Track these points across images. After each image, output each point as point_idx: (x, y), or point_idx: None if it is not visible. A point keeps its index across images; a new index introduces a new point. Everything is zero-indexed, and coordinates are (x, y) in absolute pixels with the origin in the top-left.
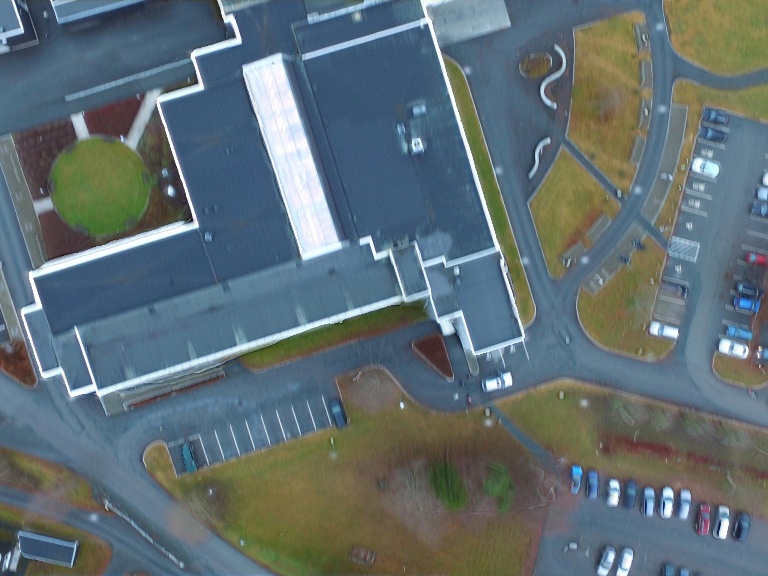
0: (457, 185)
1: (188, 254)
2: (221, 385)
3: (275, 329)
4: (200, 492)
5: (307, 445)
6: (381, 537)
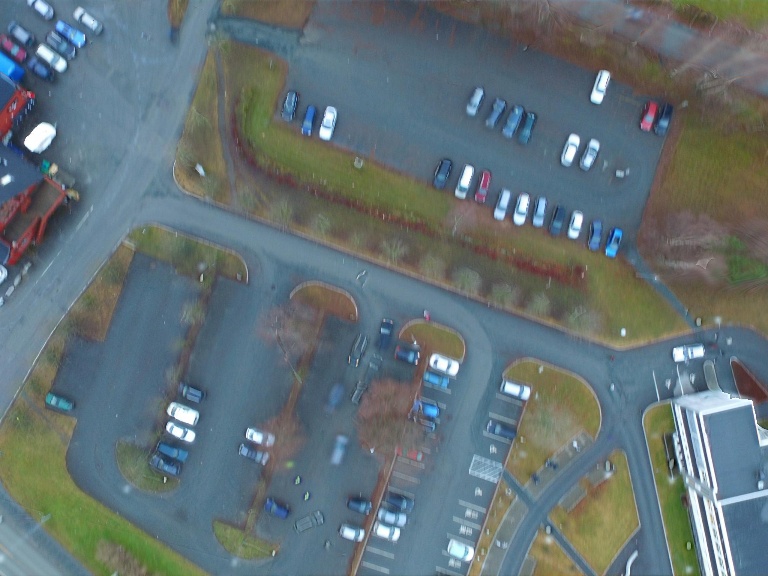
0: (751, 568)
1: None
2: None
3: None
4: None
5: None
6: None
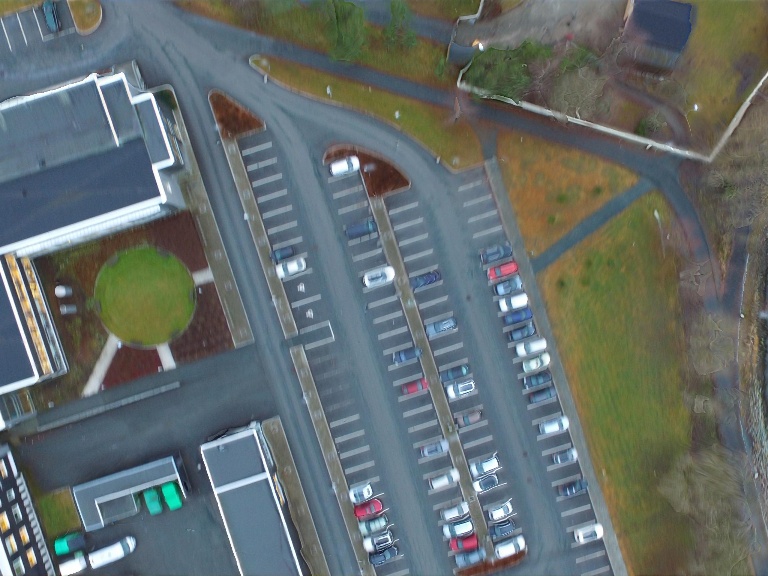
0: None
1: (7, 222)
2: (22, 93)
3: None
4: None
5: None
6: None
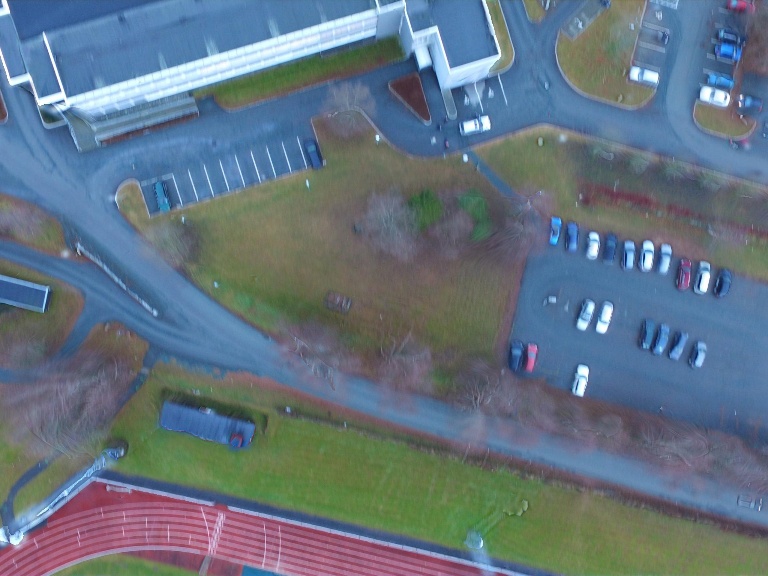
0: None
1: None
2: (195, 124)
3: (247, 41)
4: (173, 229)
5: (282, 187)
6: (357, 284)
